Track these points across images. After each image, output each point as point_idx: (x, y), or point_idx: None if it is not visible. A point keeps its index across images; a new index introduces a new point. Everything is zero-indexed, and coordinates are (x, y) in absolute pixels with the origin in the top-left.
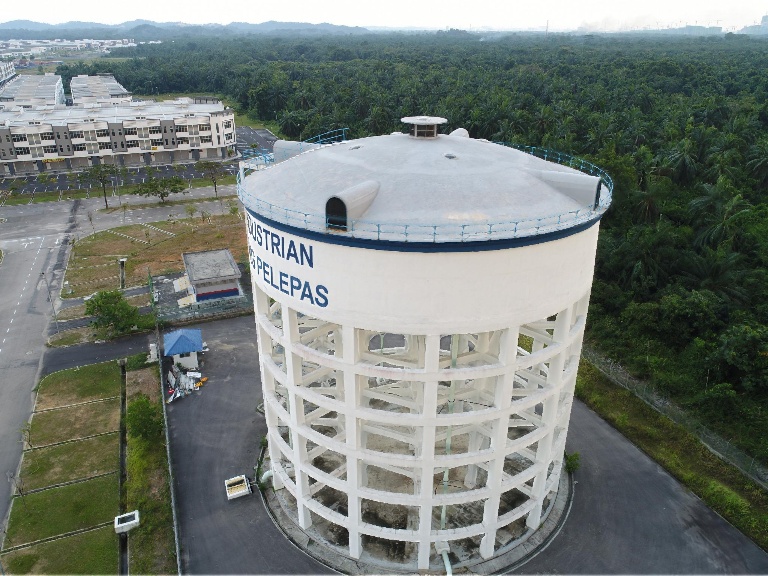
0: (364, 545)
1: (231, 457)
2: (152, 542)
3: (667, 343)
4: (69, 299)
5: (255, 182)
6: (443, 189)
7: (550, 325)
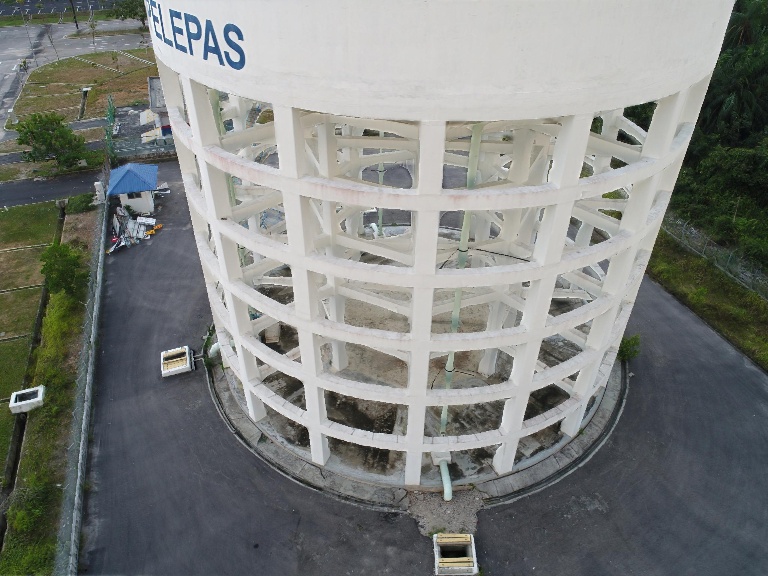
0: (334, 447)
1: (175, 323)
2: (55, 427)
3: (759, 201)
4: (14, 130)
5: None
6: None
7: None
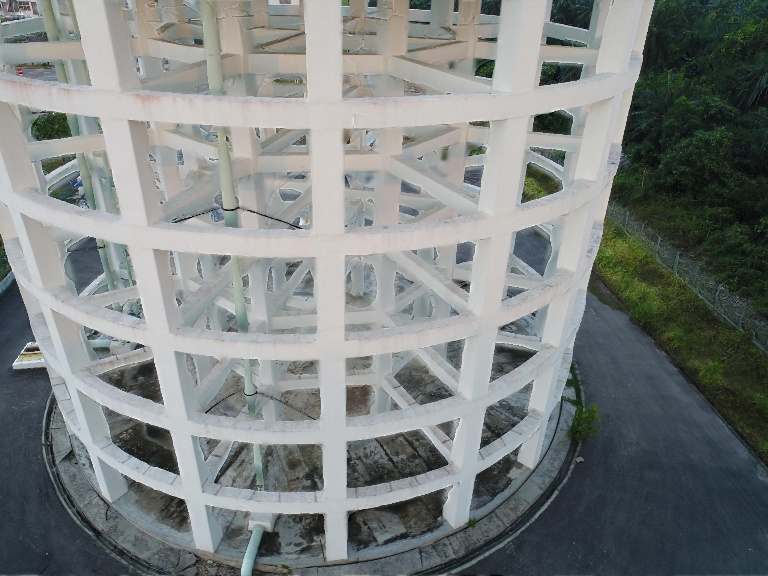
0: None
1: None
2: None
3: None
4: None
5: None
6: None
7: (567, 141)
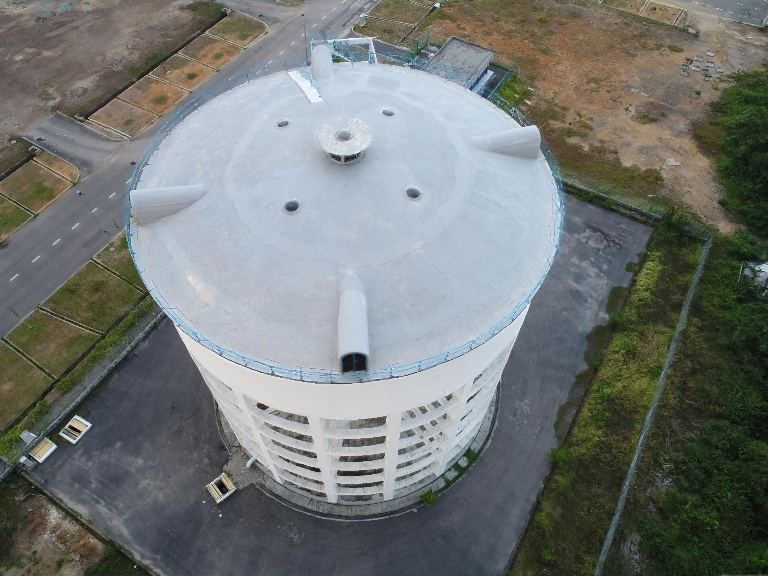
0: None
1: None
2: None
3: (760, 518)
4: (355, 33)
5: (232, 97)
6: (222, 244)
7: None
